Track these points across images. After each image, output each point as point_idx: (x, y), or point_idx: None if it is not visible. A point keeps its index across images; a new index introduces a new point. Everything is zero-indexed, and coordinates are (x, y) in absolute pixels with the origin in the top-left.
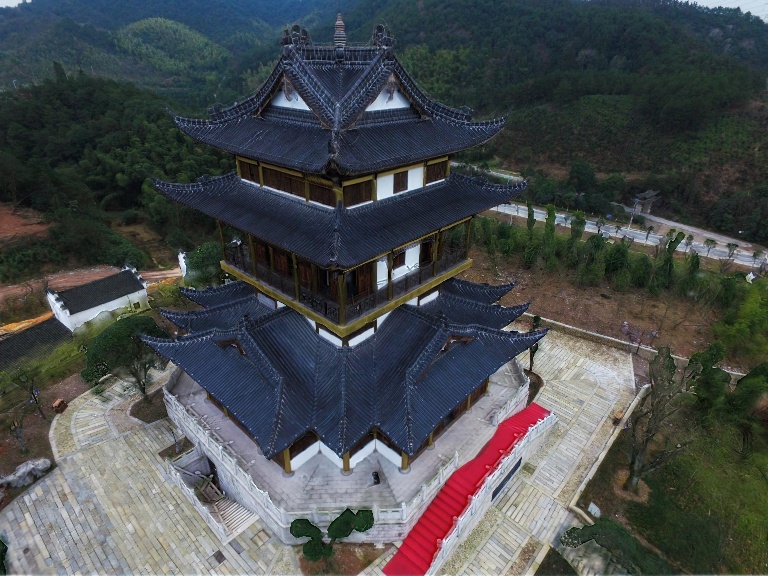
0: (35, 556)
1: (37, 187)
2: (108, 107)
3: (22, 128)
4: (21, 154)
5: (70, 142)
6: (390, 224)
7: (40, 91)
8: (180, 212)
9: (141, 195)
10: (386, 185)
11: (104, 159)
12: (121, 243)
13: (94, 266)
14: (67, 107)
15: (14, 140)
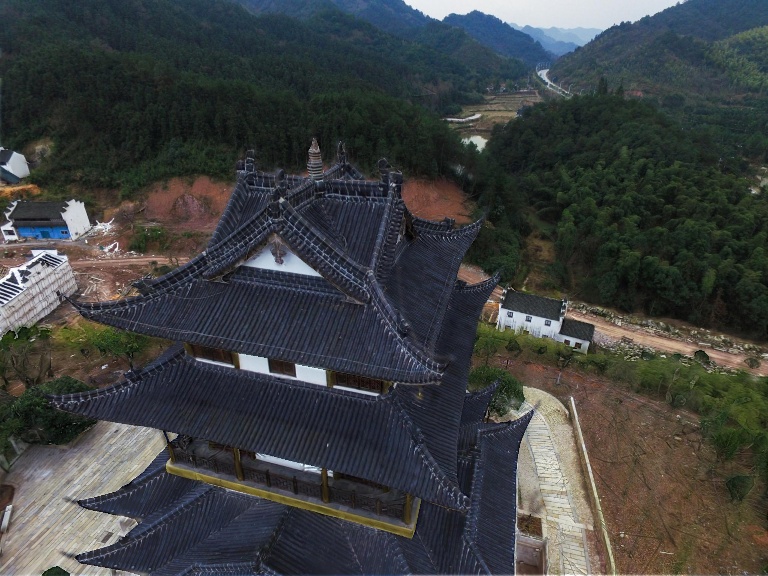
0: (112, 438)
1: (486, 188)
2: (606, 126)
3: (532, 135)
4: (520, 155)
5: (556, 153)
6: (213, 404)
7: (565, 105)
8: (578, 246)
9: (561, 217)
10: (255, 358)
11: (563, 175)
12: (507, 254)
13: (472, 265)
14: (575, 121)
15: (522, 143)
